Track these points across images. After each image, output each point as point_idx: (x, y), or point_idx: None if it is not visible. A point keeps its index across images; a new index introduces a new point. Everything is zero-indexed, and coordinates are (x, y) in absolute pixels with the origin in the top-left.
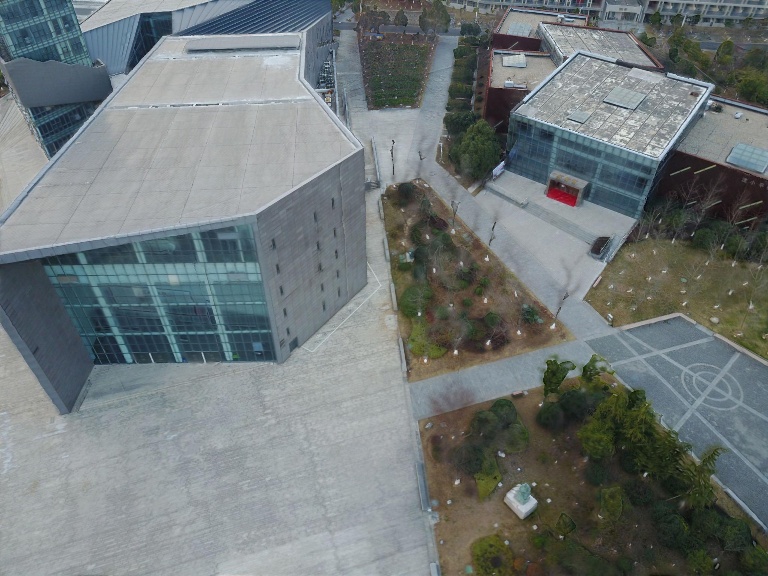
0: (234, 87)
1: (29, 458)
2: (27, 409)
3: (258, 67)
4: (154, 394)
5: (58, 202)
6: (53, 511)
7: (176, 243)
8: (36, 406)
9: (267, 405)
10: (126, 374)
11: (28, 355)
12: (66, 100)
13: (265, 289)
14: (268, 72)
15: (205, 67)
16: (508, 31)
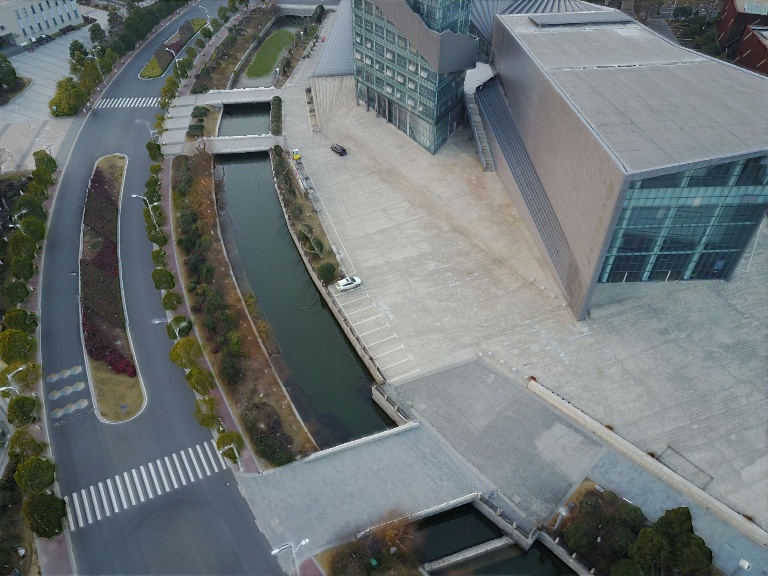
0: (628, 53)
1: (579, 352)
2: (546, 318)
3: (622, 37)
4: (642, 305)
5: (630, 135)
6: (631, 389)
7: (722, 168)
8: (551, 315)
9: (742, 311)
10: (607, 290)
11: (601, 263)
12: (456, 68)
13: (766, 209)
14: (637, 41)
15: (576, 38)
16: (746, 10)
